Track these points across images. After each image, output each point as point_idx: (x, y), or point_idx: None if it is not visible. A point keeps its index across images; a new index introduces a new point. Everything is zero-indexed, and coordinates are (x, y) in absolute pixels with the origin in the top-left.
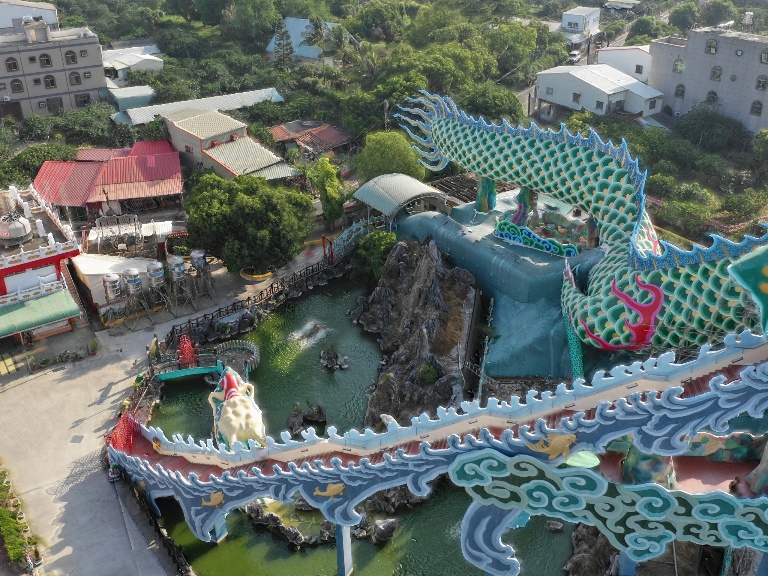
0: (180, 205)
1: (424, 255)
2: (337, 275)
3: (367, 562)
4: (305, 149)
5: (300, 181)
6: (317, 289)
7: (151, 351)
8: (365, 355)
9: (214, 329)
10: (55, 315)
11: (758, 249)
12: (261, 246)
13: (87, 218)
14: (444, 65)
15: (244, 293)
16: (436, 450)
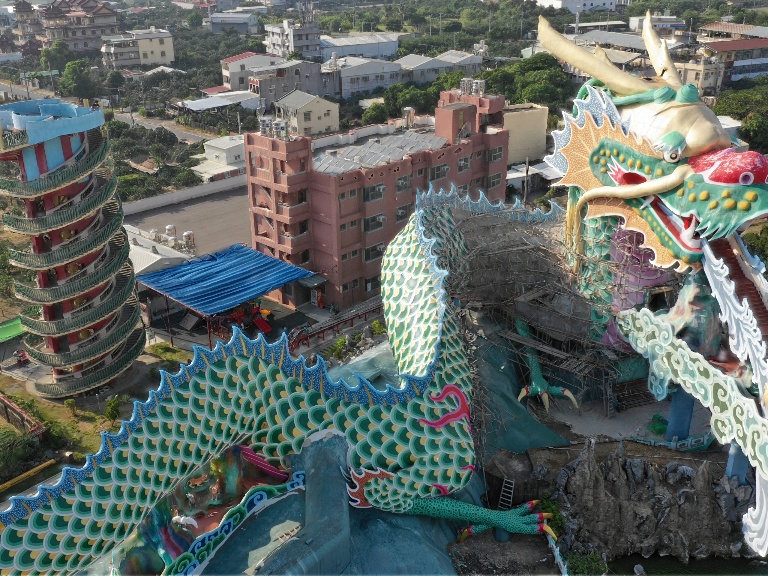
0: None
1: None
2: None
3: None
4: None
5: None
6: None
7: None
8: None
9: None
10: None
11: (760, 193)
12: None
13: None
14: None
15: None
16: None
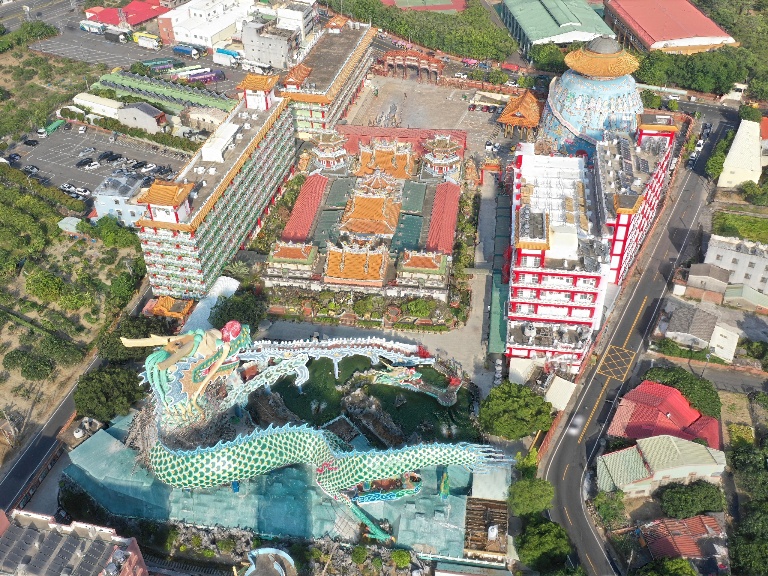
0: None
1: None
2: None
3: (336, 383)
4: None
5: None
6: None
7: None
8: (422, 438)
9: None
10: None
11: (244, 327)
12: None
13: None
14: None
15: None
16: None
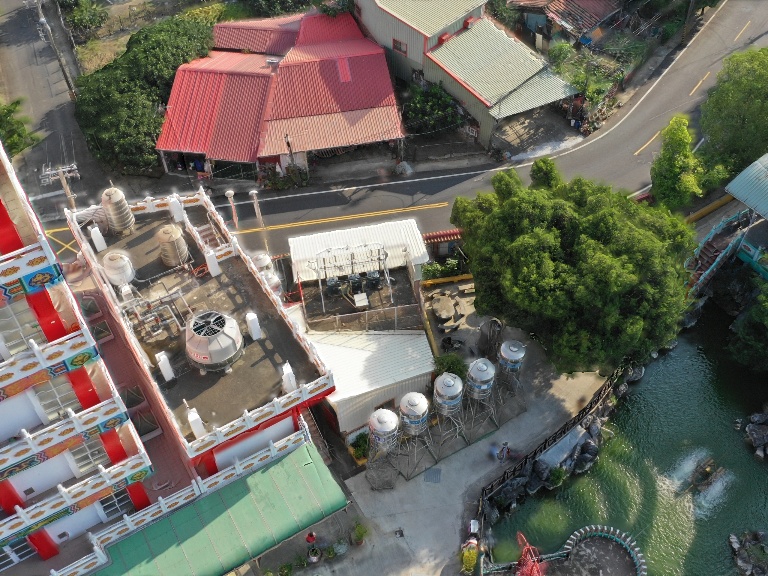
0: (395, 150)
1: None
2: (688, 324)
3: None
4: (562, 28)
5: (573, 102)
6: (662, 354)
7: (468, 564)
8: None
9: (539, 477)
10: (308, 517)
11: None
12: (625, 340)
13: (257, 176)
14: None
15: (560, 379)
16: None
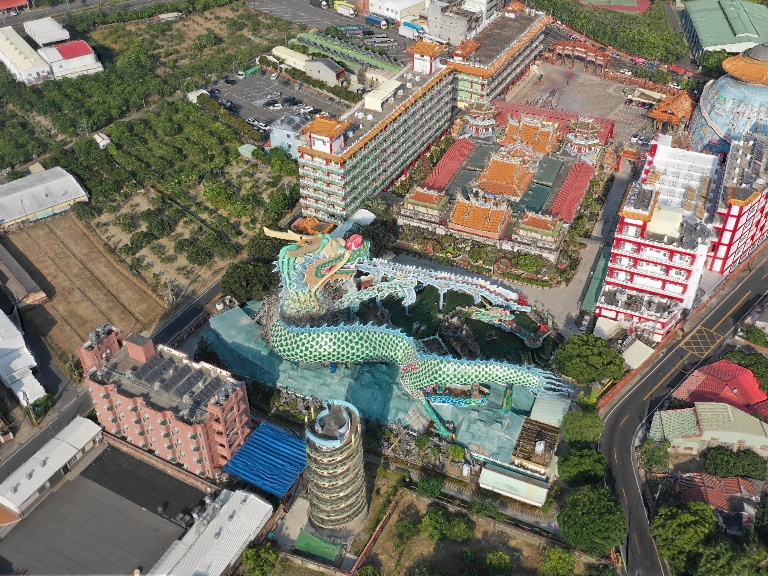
0: None
1: None
2: None
3: None
4: None
5: None
6: None
7: None
8: None
9: None
10: None
11: None
12: None
13: None
14: (700, 575)
15: None
16: (418, 269)
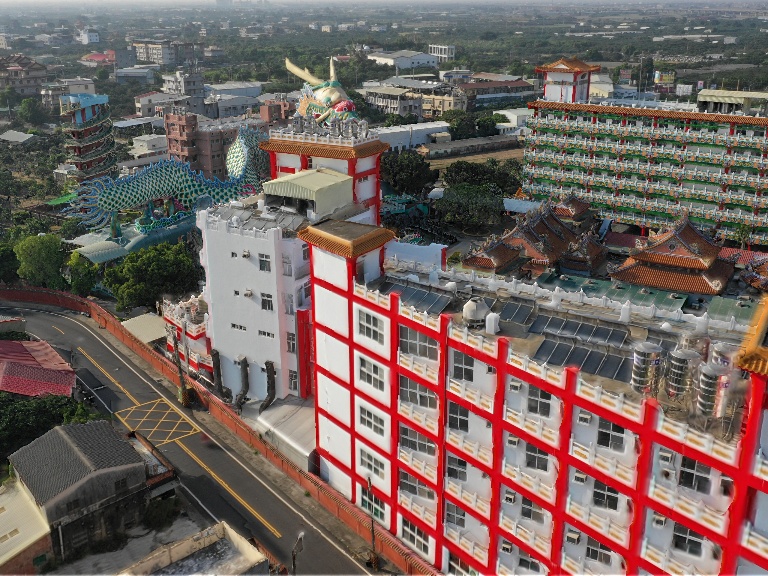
0: None
1: (194, 235)
2: None
3: None
4: None
5: None
6: None
7: None
8: None
9: None
10: None
11: None
12: None
13: None
14: None
15: None
16: None
